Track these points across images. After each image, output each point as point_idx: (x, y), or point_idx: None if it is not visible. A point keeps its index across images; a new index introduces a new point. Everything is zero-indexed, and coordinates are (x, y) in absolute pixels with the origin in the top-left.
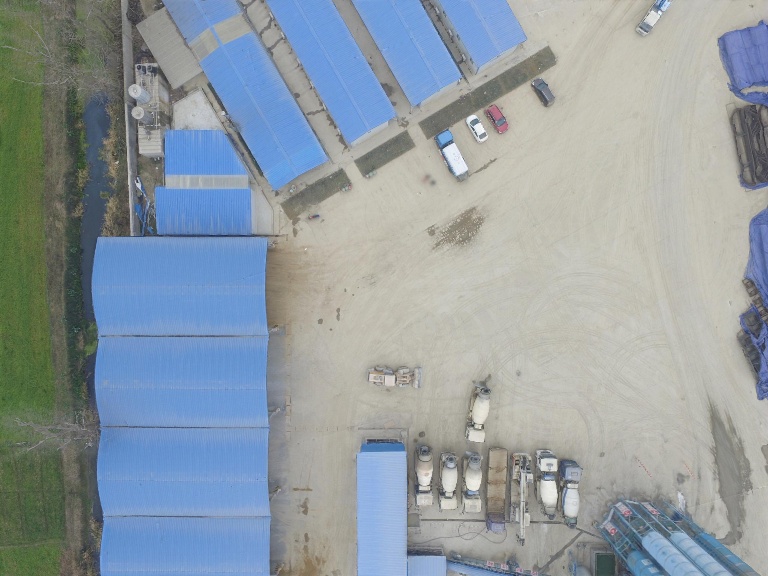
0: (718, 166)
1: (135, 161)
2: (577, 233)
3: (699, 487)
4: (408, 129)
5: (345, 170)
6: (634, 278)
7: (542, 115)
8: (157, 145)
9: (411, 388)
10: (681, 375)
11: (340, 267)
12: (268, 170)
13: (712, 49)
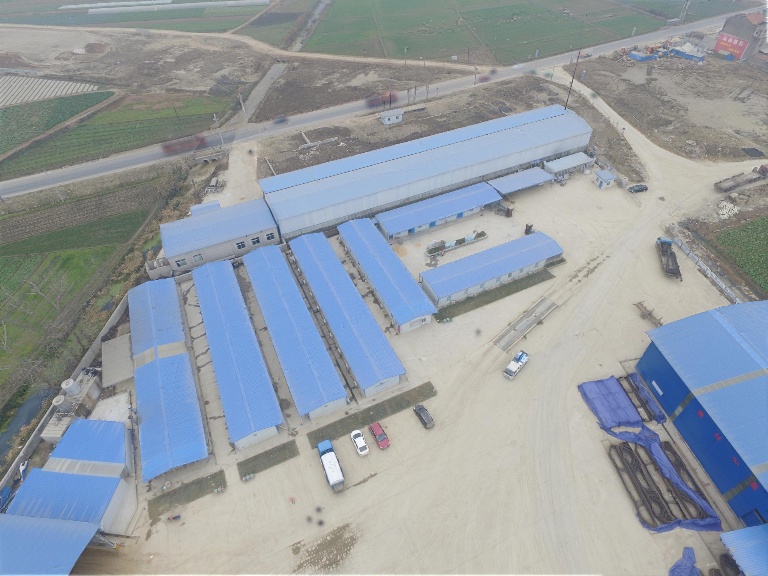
0: (610, 502)
1: (35, 446)
2: (462, 568)
3: None
4: (296, 438)
5: (225, 472)
6: None
7: (423, 436)
8: (60, 430)
9: None
10: None
11: None
12: (147, 461)
13: (575, 394)
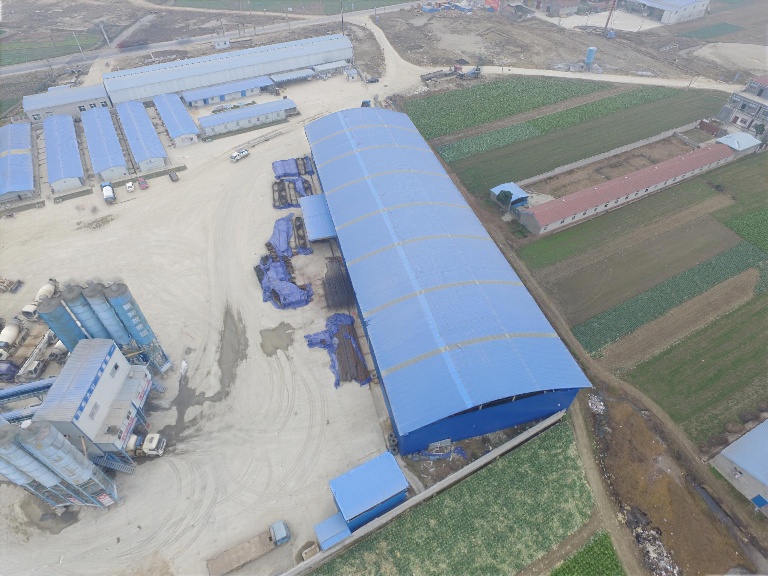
0: (262, 201)
1: None
2: (169, 224)
3: (202, 357)
4: (93, 188)
5: (46, 201)
6: (196, 243)
7: (171, 184)
8: None
9: (8, 294)
10: (211, 289)
11: (9, 237)
12: None
13: None
